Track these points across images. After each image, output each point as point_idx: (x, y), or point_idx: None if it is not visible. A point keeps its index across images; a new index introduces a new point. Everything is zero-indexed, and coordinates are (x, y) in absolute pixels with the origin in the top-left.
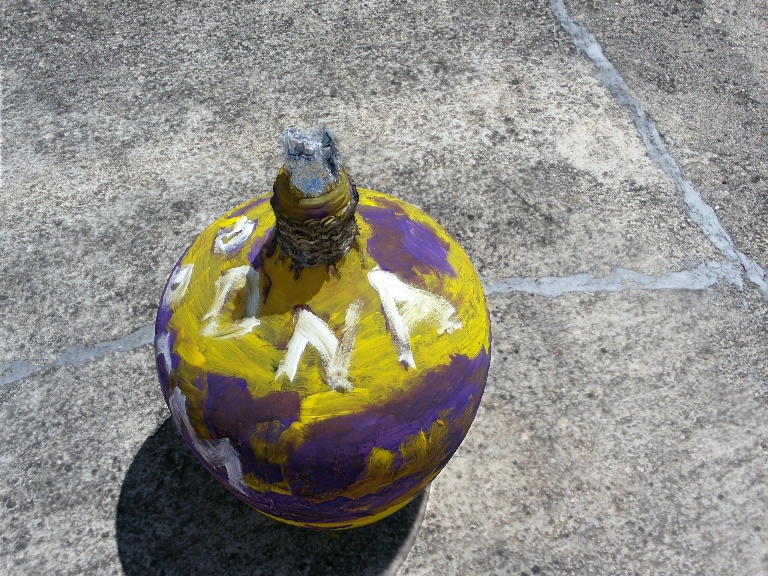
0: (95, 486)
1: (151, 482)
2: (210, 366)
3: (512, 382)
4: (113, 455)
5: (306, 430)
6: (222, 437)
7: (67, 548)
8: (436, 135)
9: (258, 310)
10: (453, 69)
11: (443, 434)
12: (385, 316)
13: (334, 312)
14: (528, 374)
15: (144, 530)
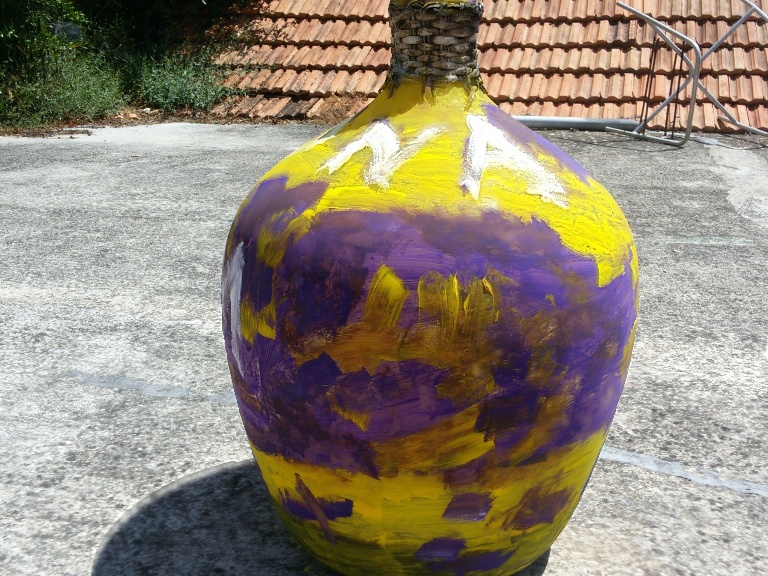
0: (150, 473)
1: (201, 488)
2: (269, 177)
3: (703, 564)
4: (188, 460)
5: (316, 220)
6: (239, 243)
7: (78, 501)
8: (717, 372)
9: (340, 130)
10: (766, 342)
11: (490, 317)
12: (467, 147)
13: (411, 128)
14: (733, 565)
15: (157, 516)
